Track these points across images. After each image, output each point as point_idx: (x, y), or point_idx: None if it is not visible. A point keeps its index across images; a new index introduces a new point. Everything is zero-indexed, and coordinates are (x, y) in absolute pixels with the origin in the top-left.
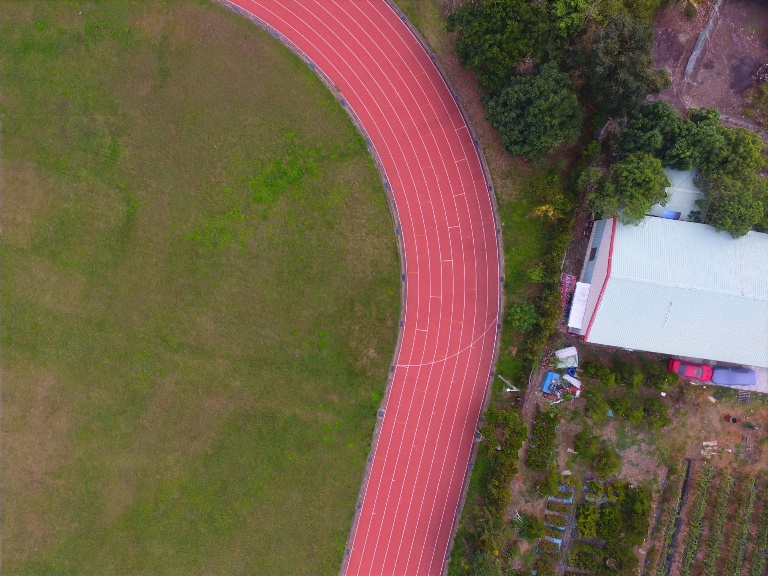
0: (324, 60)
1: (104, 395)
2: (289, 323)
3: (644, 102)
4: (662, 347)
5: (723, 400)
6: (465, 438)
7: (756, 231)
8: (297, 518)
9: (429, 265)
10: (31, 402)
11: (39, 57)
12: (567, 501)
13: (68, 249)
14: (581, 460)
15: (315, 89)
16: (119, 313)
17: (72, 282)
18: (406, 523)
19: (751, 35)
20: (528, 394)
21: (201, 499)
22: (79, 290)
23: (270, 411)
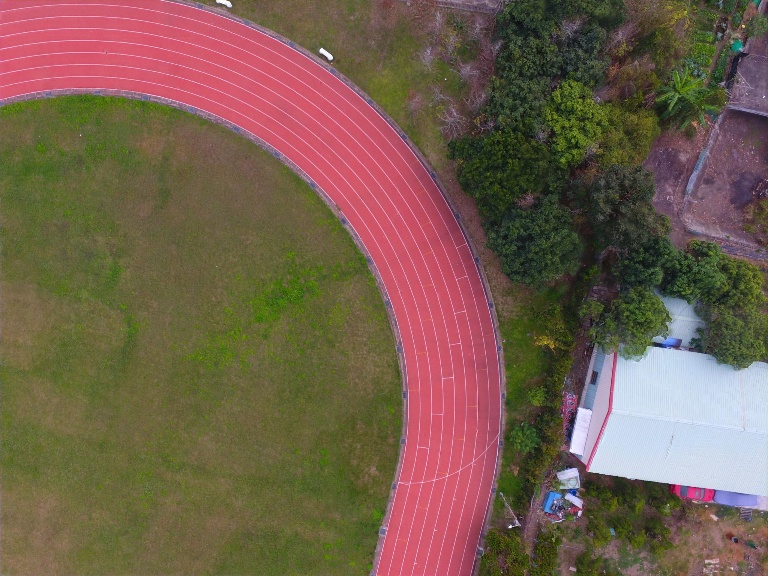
0: (325, 179)
1: (106, 516)
2: (291, 442)
3: None
4: (664, 478)
5: (725, 518)
6: (467, 555)
7: (757, 361)
8: None
9: (430, 383)
10: (33, 524)
11: (40, 179)
12: None
13: (69, 370)
14: None
15: (316, 208)
16: (121, 434)
17: (73, 403)
18: None
19: (751, 151)
20: (530, 517)
21: None
22: (81, 411)
23: (272, 530)
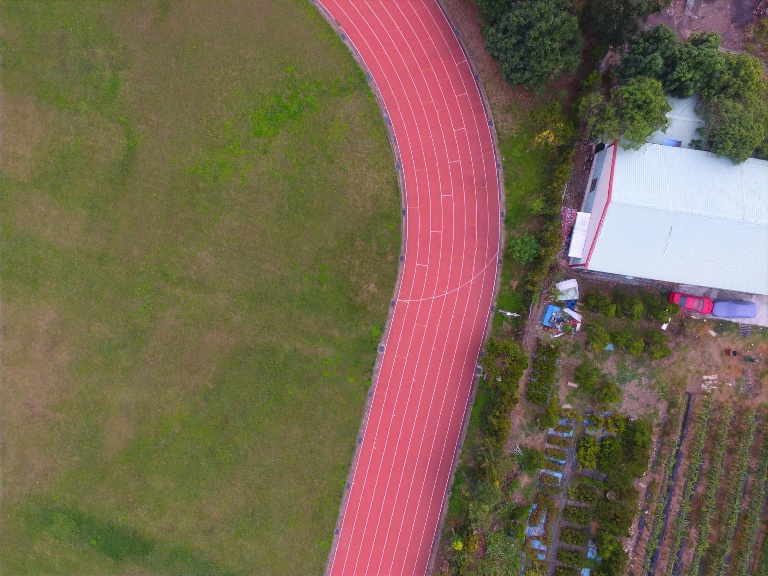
0: None
1: (105, 329)
2: (289, 257)
3: (645, 28)
4: (663, 274)
5: (724, 334)
6: (465, 373)
7: (757, 158)
8: (298, 452)
9: (429, 200)
10: (32, 335)
11: None
12: (567, 435)
13: (68, 183)
14: (581, 394)
15: (315, 23)
16: (120, 247)
17: (72, 216)
18: (407, 458)
19: None
20: (528, 326)
21: (202, 433)
22: (79, 224)
23: (271, 345)
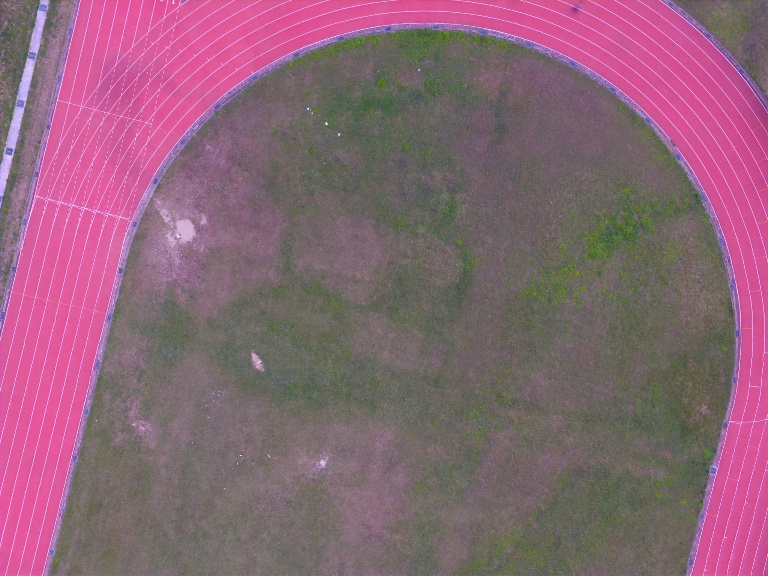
0: (660, 114)
1: (440, 450)
2: (623, 379)
3: None
4: None
5: None
6: None
7: None
8: (629, 574)
9: (764, 321)
10: (369, 457)
11: (378, 114)
12: None
13: (406, 305)
14: None
15: (651, 144)
16: (455, 369)
17: (409, 338)
18: None
19: None
20: None
21: (535, 554)
22: (416, 346)
23: (603, 467)
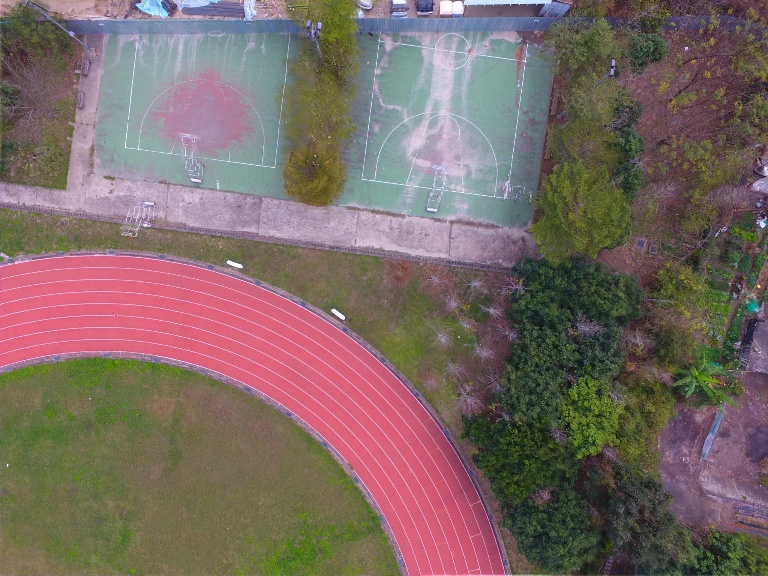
0: (337, 438)
1: None
2: None
3: None
4: None
5: None
6: None
7: None
8: None
9: None
10: None
11: (48, 443)
12: None
13: None
14: None
15: (328, 468)
16: None
17: None
18: None
19: (767, 403)
20: None
21: None
22: None
23: None
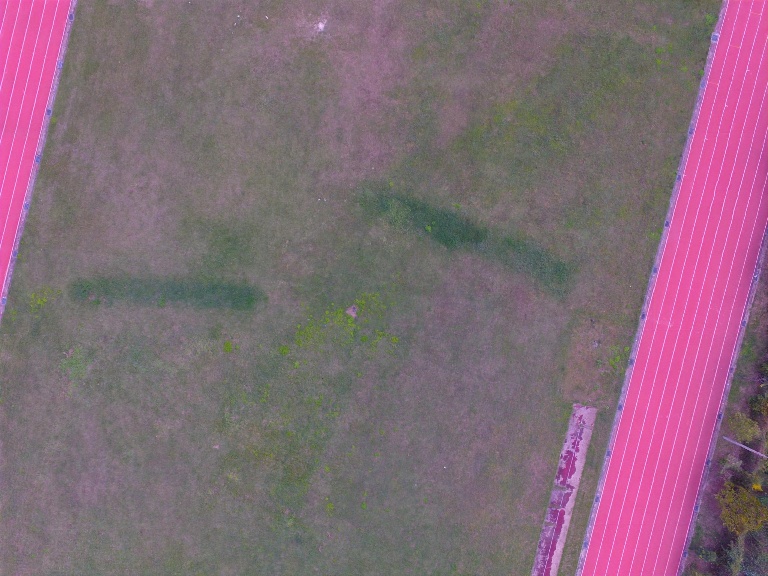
0: None
1: (439, 14)
2: None
3: None
4: None
5: None
6: None
7: None
8: (629, 142)
9: None
10: (368, 20)
11: None
12: None
13: None
14: None
15: None
16: None
17: None
18: (738, 149)
19: None
20: None
21: (534, 121)
22: None
23: (604, 33)
